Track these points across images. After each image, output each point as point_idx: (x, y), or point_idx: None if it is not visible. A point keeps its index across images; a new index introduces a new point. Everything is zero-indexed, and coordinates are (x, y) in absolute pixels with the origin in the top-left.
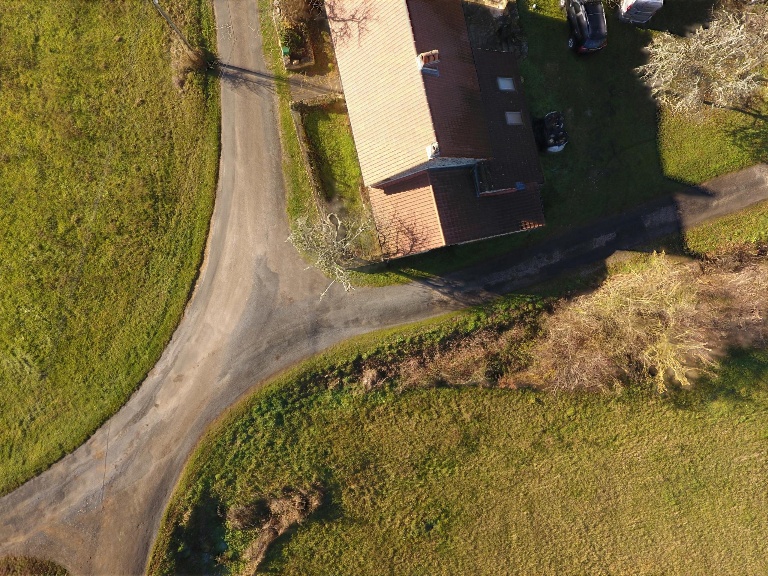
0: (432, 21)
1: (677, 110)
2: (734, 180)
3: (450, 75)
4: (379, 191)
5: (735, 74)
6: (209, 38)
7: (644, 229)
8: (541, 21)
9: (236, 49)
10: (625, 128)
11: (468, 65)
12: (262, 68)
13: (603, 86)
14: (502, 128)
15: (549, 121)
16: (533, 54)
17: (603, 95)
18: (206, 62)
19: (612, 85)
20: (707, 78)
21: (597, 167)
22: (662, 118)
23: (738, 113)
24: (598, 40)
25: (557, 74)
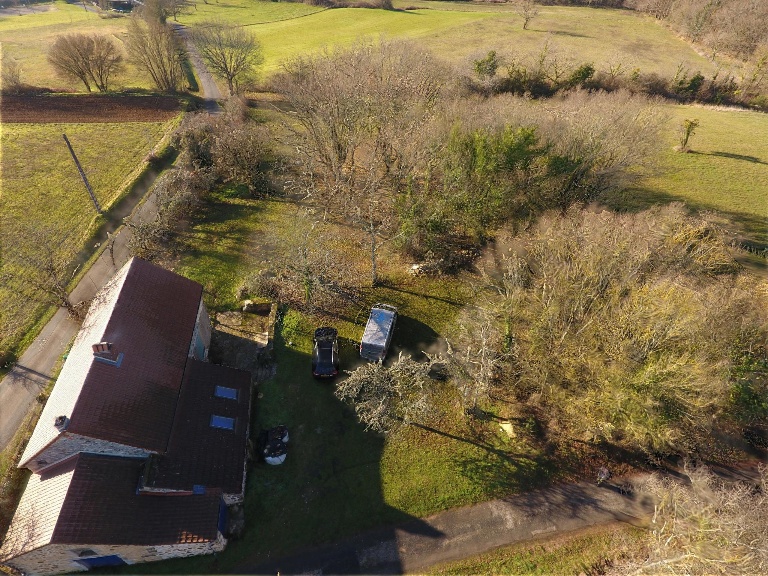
0: (140, 330)
1: (371, 426)
2: (467, 516)
3: (138, 370)
4: (38, 477)
5: (421, 397)
6: (23, 346)
7: (357, 568)
8: (293, 354)
9: (38, 355)
10: (351, 448)
11: (173, 368)
12: (48, 370)
13: (337, 408)
14: (201, 429)
15: (273, 433)
16: (279, 377)
17: (336, 416)
18: (5, 362)
19: (346, 408)
20: (395, 399)
21: (313, 485)
22: (390, 442)
23: (470, 445)
24: (326, 368)
25: (296, 395)
